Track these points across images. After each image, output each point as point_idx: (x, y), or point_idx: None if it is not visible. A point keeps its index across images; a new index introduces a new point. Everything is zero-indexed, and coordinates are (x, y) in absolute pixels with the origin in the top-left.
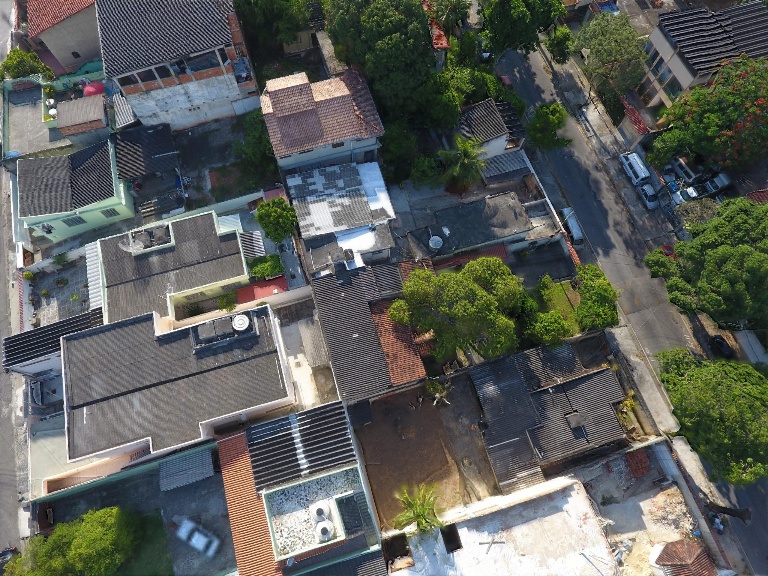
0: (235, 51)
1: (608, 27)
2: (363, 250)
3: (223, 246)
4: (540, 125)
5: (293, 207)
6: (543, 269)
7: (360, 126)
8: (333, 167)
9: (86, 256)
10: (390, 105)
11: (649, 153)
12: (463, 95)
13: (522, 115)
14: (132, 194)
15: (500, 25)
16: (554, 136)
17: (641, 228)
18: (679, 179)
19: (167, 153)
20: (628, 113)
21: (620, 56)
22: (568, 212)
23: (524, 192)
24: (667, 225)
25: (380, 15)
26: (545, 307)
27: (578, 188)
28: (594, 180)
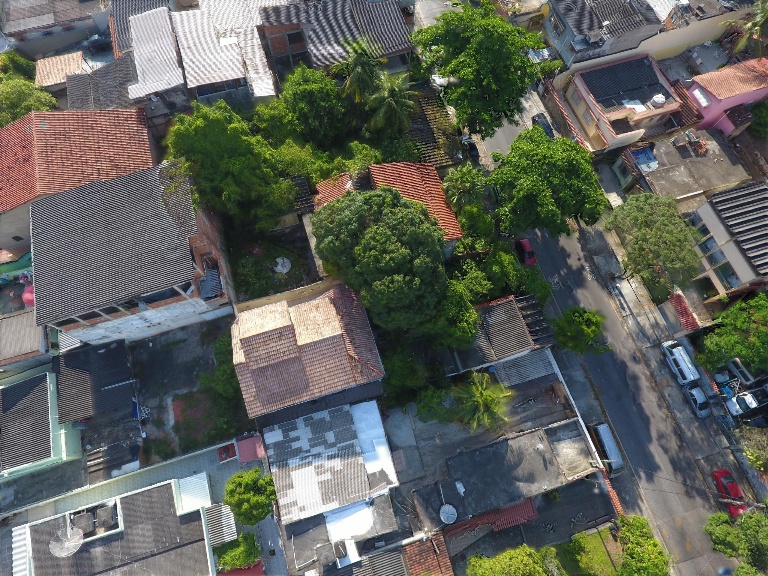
0: (201, 267)
1: (653, 217)
2: (358, 535)
3: (184, 530)
4: (572, 334)
5: (271, 477)
6: (576, 508)
7: (354, 369)
8: (321, 413)
9: (12, 546)
10: (391, 328)
11: (699, 354)
12: (478, 295)
13: (547, 299)
14: (79, 428)
15: (523, 215)
16: (587, 342)
17: (690, 442)
18: (734, 379)
19: (120, 383)
20: (673, 301)
21: (671, 264)
22: (604, 431)
23: (550, 397)
24: (721, 439)
25: (378, 249)
26: (581, 569)
27: (613, 387)
28: (632, 376)
